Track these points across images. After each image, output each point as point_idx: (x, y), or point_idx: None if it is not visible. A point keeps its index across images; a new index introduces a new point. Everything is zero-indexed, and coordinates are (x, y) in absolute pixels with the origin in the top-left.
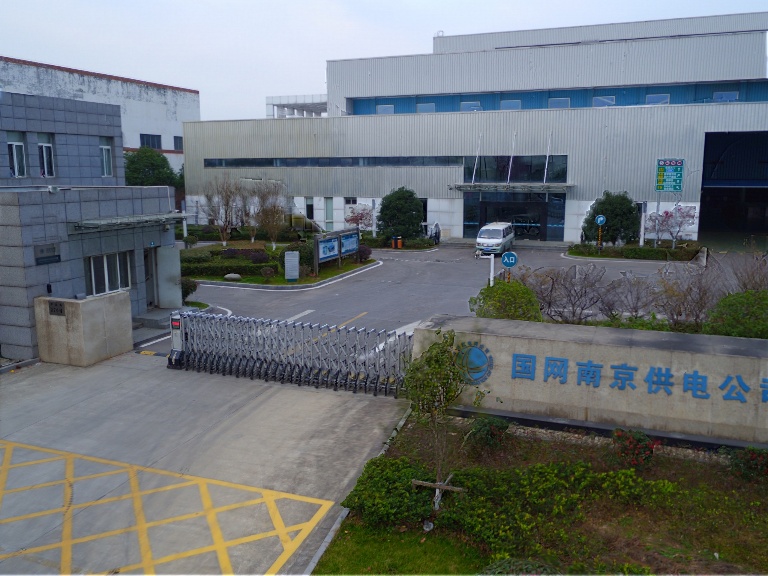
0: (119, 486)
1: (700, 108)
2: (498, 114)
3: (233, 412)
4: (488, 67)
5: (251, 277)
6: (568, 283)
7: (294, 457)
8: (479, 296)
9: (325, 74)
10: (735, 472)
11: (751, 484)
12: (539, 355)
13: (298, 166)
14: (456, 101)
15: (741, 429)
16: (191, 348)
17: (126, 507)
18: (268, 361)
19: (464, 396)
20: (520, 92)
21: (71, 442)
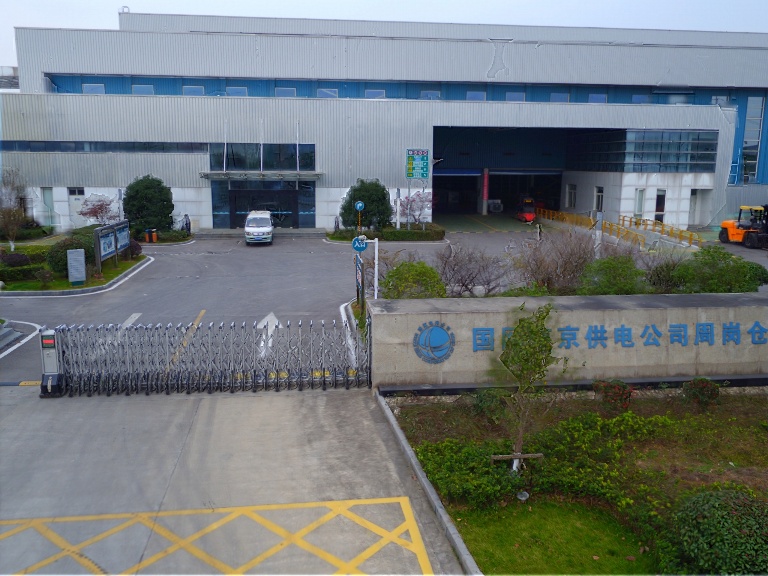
0: (148, 540)
1: (428, 104)
2: (243, 100)
3: (189, 432)
4: (213, 51)
5: (15, 283)
6: (444, 262)
7: (316, 464)
8: (388, 279)
9: (14, 43)
10: (694, 400)
11: (712, 406)
12: (496, 327)
13: (2, 150)
14: (178, 84)
15: (658, 368)
16: (70, 369)
17: (188, 560)
18: (181, 371)
19: (429, 375)
20: (246, 79)
21: (14, 506)
